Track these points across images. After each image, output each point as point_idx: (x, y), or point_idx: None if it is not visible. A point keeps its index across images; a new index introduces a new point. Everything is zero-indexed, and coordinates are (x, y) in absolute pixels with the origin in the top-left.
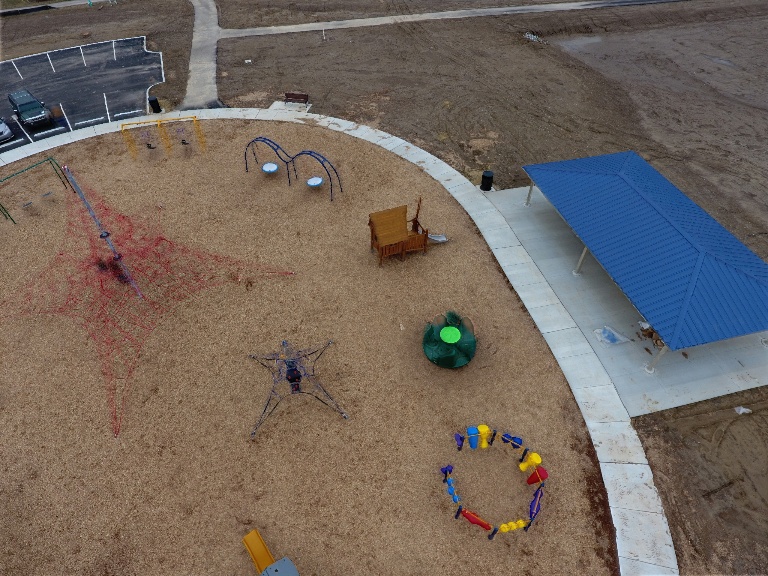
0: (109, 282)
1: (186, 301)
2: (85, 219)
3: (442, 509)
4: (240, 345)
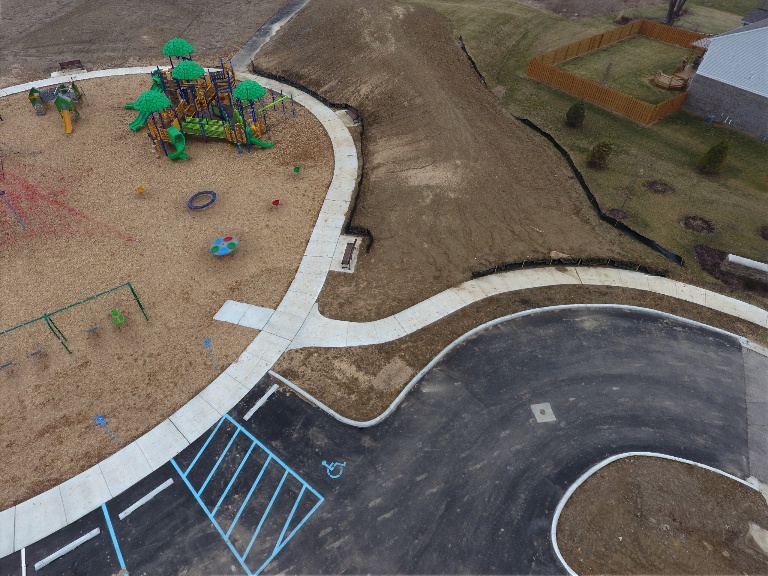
0: (36, 247)
1: (3, 219)
2: (2, 325)
3: (4, 123)
4: (3, 185)
